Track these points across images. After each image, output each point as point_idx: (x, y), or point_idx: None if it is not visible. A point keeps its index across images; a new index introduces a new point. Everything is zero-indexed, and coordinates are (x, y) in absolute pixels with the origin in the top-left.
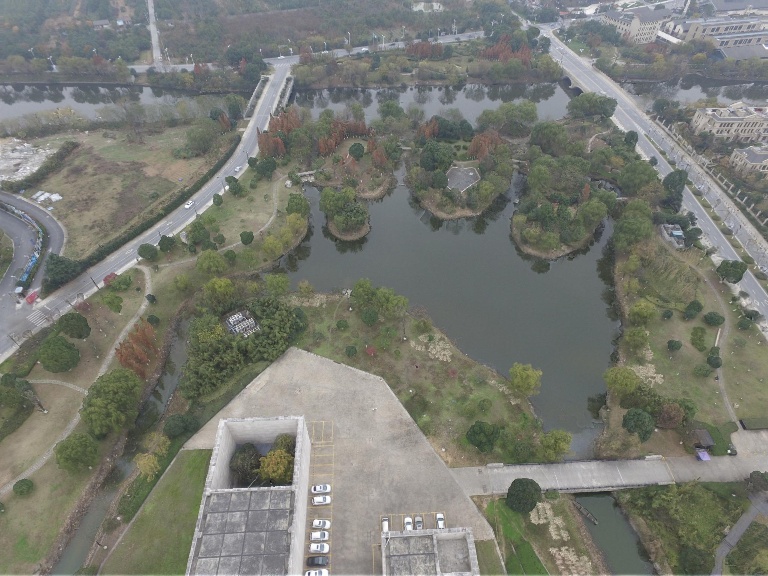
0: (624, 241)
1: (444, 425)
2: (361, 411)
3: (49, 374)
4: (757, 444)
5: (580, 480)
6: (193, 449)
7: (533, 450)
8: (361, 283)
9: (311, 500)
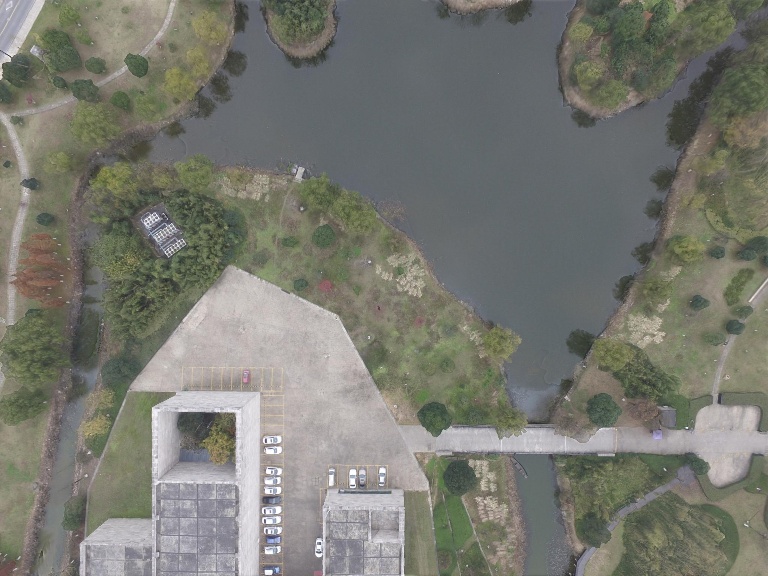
0: (725, 115)
1: (401, 379)
2: (312, 358)
3: None
4: (721, 419)
5: (524, 445)
6: (141, 391)
7: (487, 410)
8: (312, 186)
9: (263, 449)
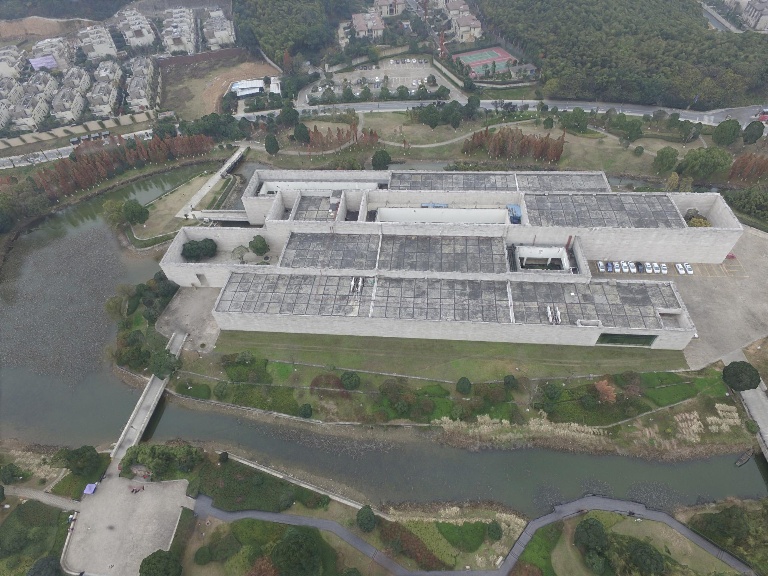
0: None
1: None
2: None
3: (709, 141)
4: None
5: None
6: None
7: None
8: None
9: None
